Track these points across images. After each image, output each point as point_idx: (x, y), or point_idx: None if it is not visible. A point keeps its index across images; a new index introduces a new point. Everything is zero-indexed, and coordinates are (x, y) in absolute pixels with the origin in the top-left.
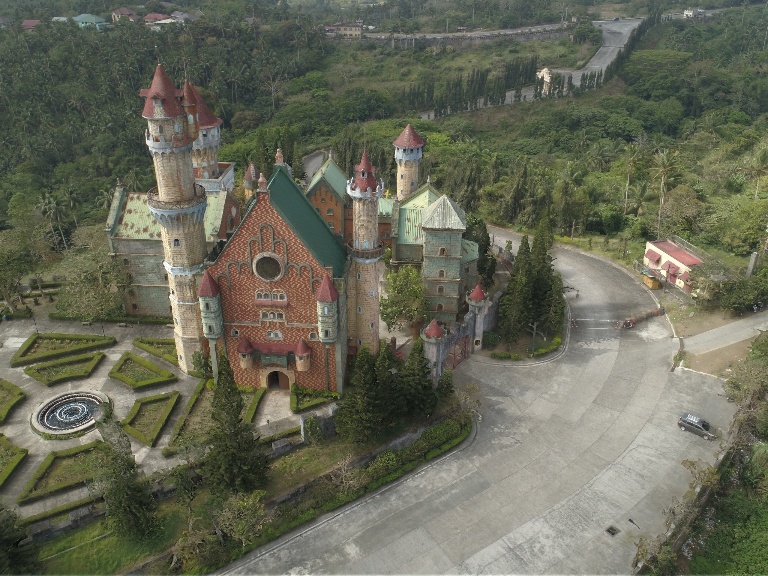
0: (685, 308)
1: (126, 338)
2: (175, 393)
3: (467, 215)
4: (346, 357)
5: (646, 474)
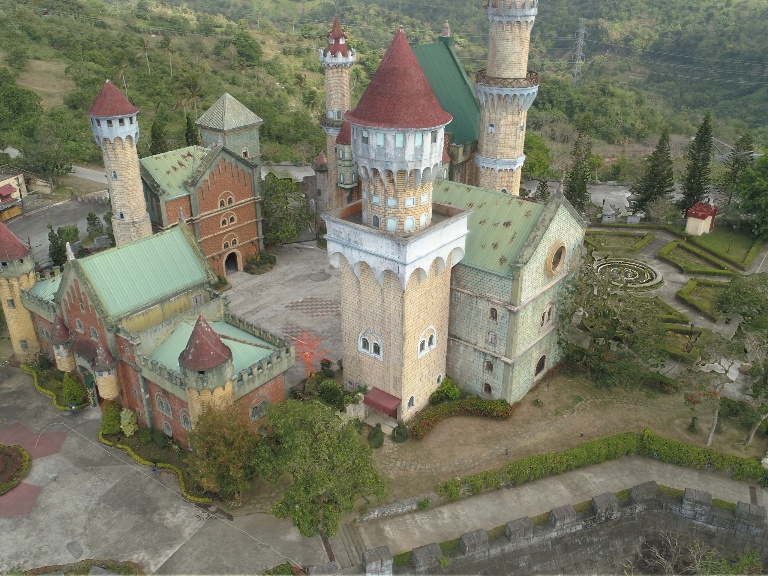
0: (57, 194)
1: None
2: None
3: None
4: None
5: (279, 173)
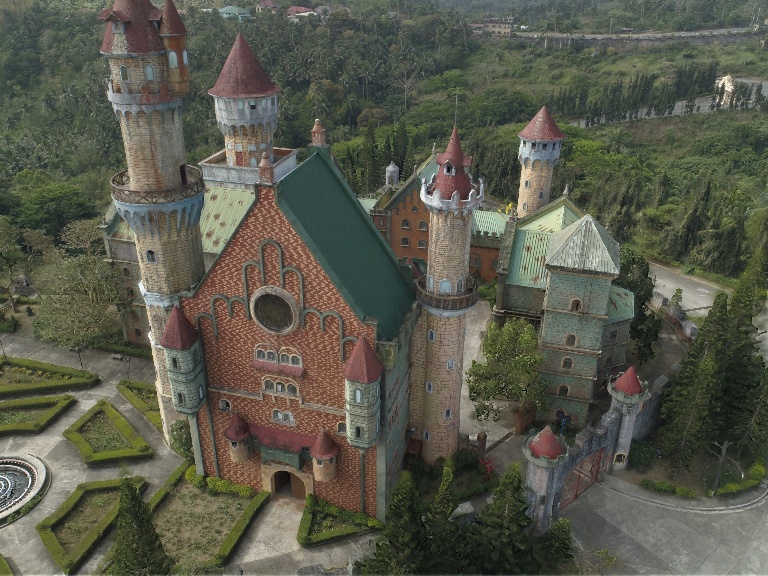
0: None
1: (114, 377)
2: (137, 481)
3: (621, 248)
4: (402, 457)
5: None
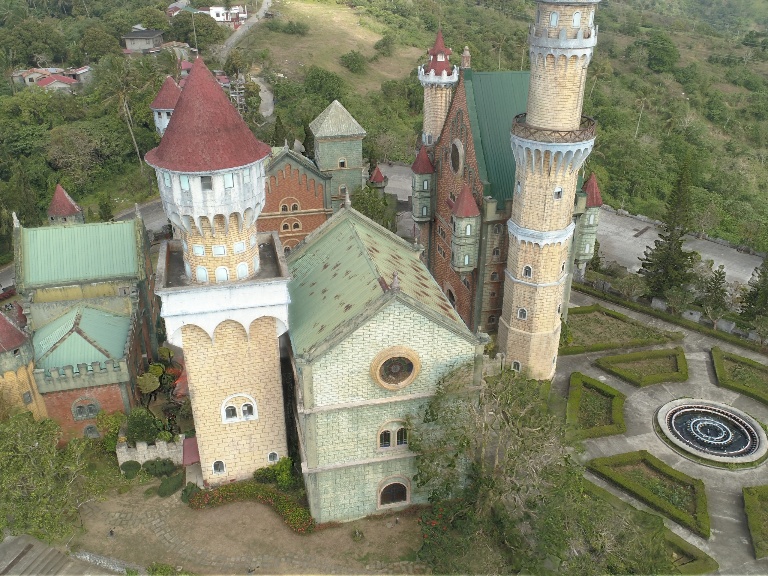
0: None
1: None
2: None
3: None
4: None
5: None
